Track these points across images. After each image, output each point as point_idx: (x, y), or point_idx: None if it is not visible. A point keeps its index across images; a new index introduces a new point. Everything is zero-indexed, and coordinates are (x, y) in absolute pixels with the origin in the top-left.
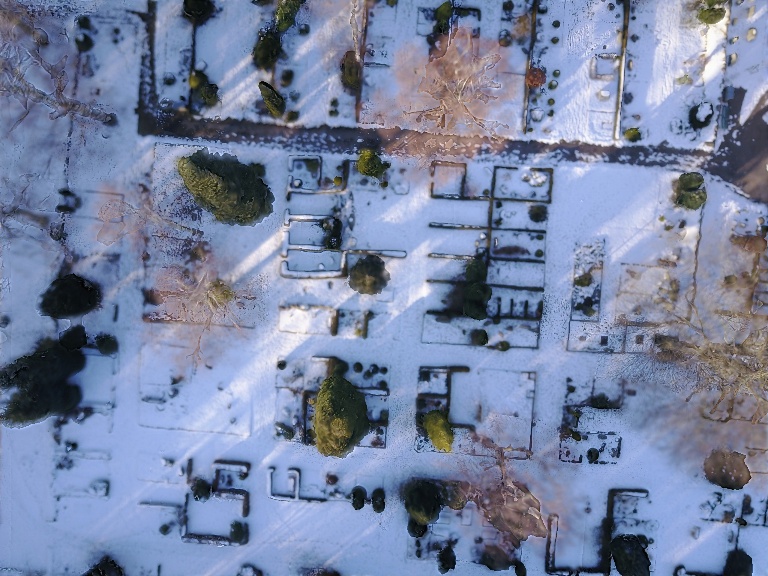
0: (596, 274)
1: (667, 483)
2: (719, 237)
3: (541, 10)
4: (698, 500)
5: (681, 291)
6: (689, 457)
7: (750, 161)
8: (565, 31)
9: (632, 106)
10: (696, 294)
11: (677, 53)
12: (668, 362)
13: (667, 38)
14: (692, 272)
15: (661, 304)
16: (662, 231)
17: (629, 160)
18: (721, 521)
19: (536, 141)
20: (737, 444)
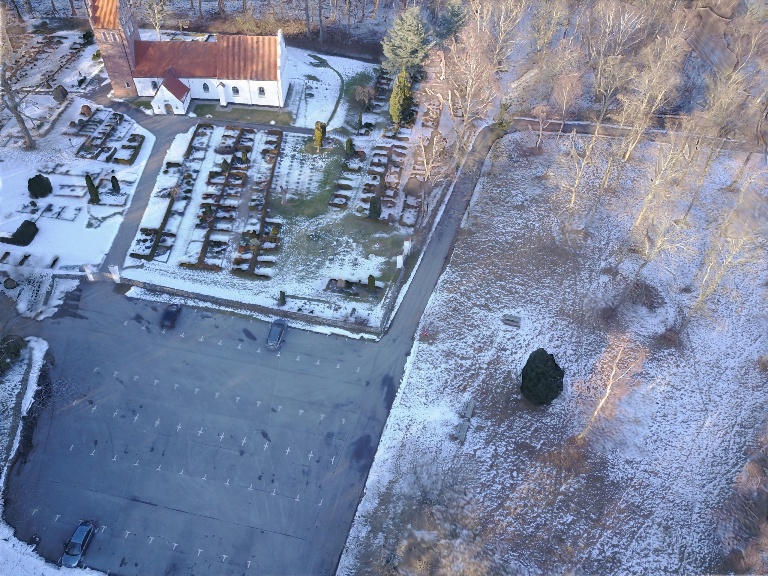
0: (5, 121)
1: (3, 196)
2: (75, 113)
3: (30, 62)
4: (18, 204)
5: (45, 126)
6: (23, 187)
7: (101, 94)
8: (38, 67)
9: (55, 82)
10: (54, 129)
11: (84, 71)
12: (28, 151)
13: (82, 68)
14: (53, 120)
15: (33, 130)
16: (47, 111)
17: (44, 94)
18: (28, 213)
19: (3, 89)
20: (55, 184)
